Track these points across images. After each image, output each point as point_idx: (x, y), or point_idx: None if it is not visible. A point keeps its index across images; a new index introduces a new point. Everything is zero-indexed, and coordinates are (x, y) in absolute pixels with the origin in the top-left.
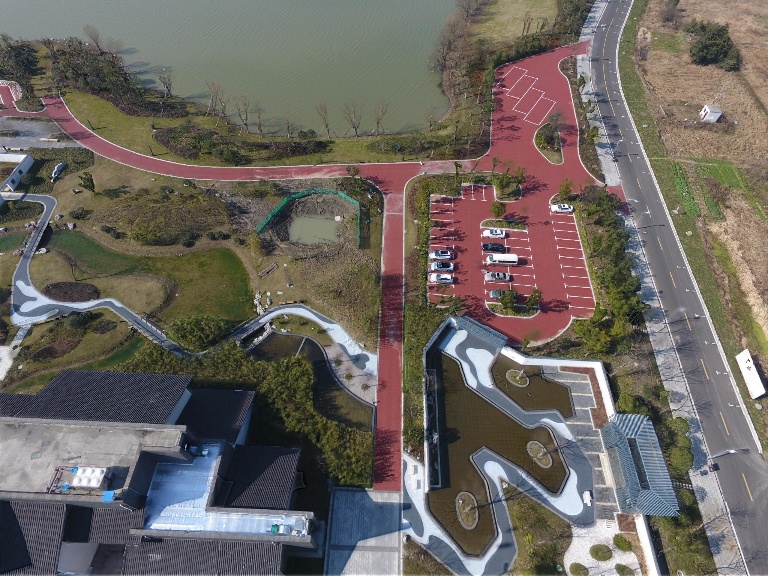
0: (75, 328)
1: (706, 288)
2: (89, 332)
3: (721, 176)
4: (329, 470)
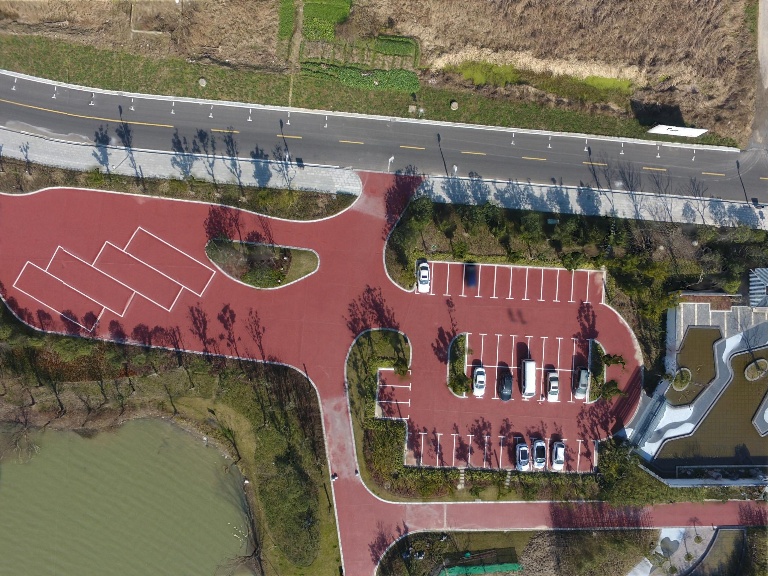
0: None
1: (546, 121)
2: None
3: (328, 5)
4: None
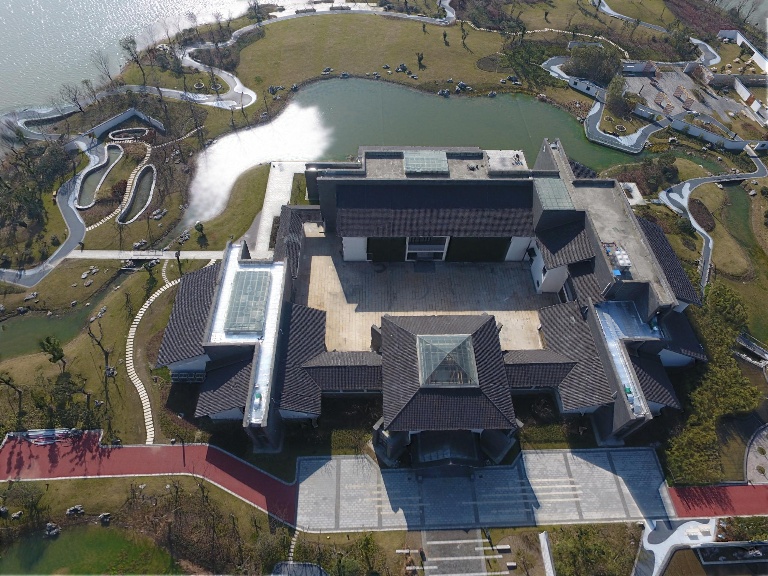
0: (678, 227)
1: None
2: (680, 236)
3: None
4: (674, 437)
